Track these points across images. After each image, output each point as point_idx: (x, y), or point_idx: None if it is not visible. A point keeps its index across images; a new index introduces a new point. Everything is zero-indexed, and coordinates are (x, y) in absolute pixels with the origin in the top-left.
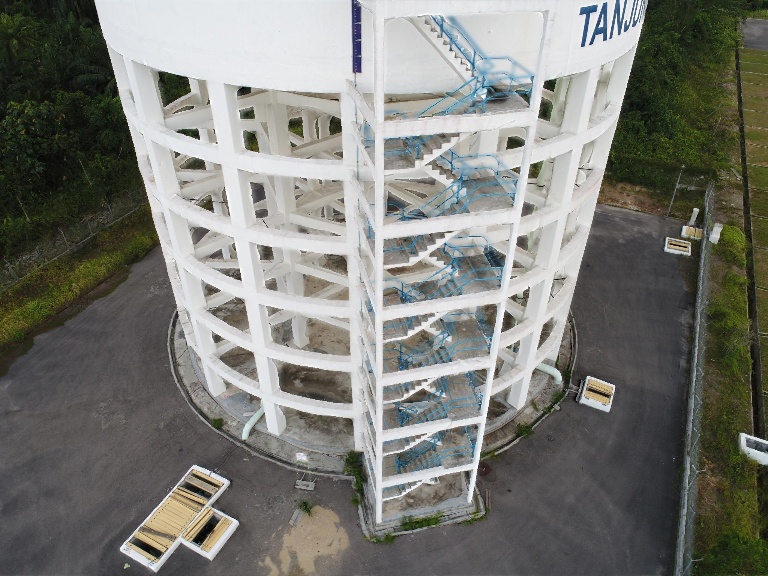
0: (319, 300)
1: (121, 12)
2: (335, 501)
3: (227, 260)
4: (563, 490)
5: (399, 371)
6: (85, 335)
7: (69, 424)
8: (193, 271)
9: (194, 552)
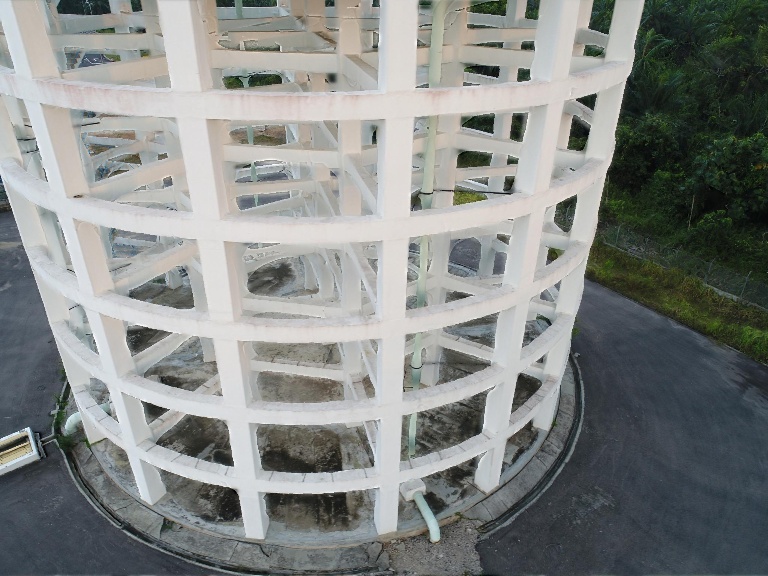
0: None
1: None
2: None
3: None
4: (5, 369)
5: None
6: None
7: None
8: None
9: None
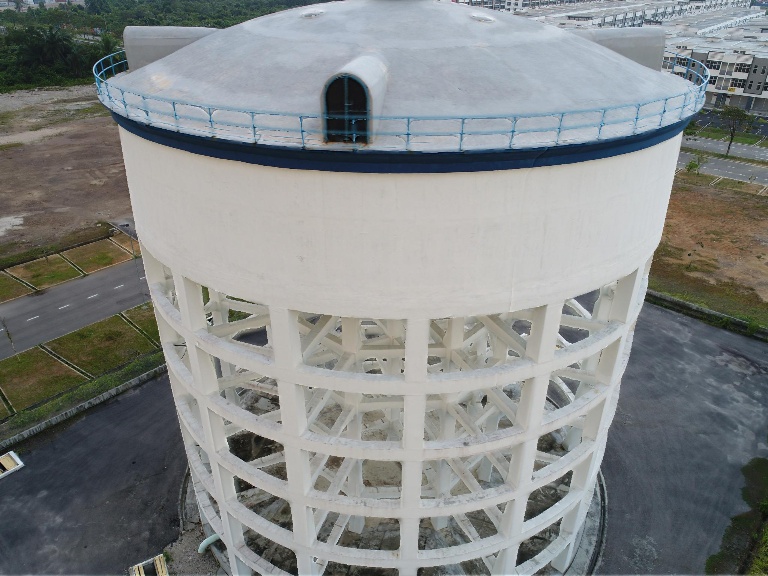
0: None
1: None
2: None
3: (549, 456)
4: None
5: None
6: (694, 497)
7: (647, 414)
8: None
9: None
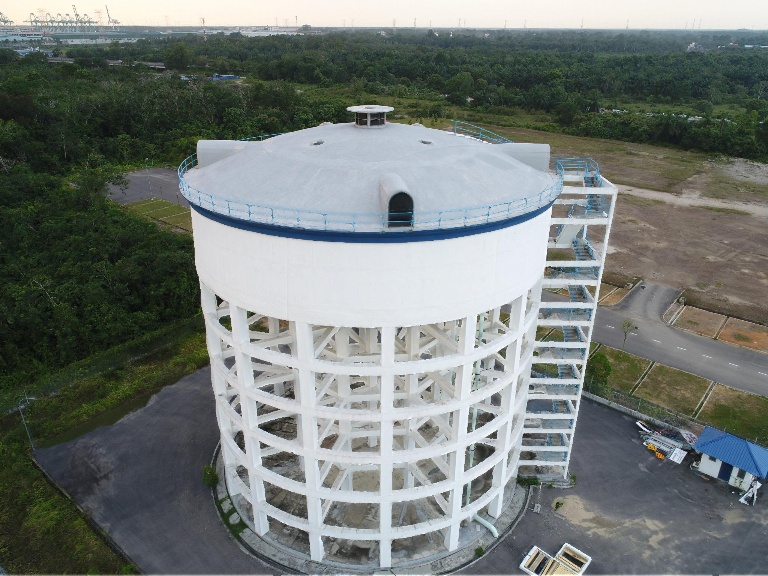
0: (522, 388)
1: (480, 288)
2: (548, 497)
3: None
4: None
5: (578, 373)
6: None
7: None
8: (478, 438)
9: (587, 569)
